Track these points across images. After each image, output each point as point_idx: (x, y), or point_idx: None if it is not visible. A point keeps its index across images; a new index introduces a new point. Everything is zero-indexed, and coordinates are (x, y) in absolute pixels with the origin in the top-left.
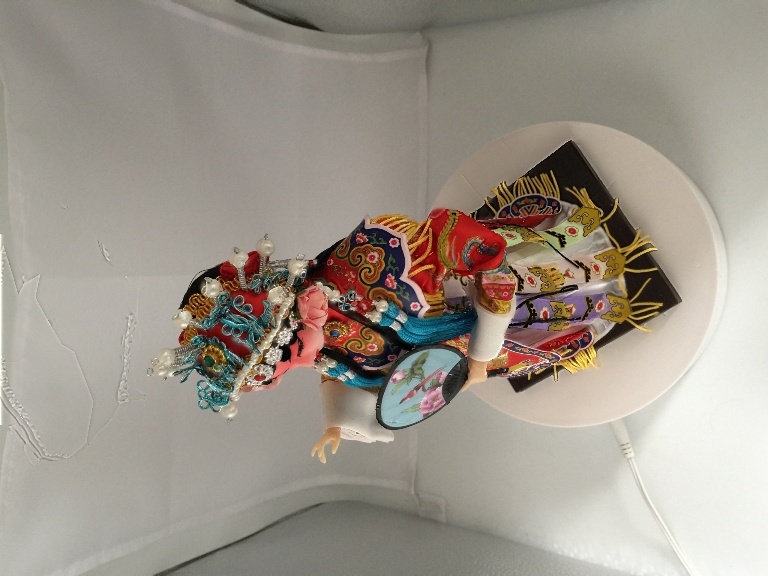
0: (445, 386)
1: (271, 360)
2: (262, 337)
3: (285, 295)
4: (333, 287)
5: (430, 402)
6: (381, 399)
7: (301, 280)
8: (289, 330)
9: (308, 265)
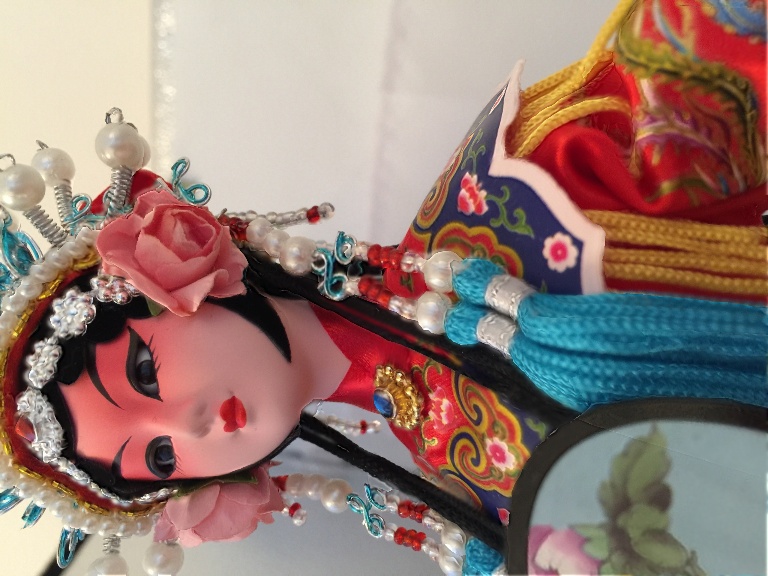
0: None
1: (34, 371)
2: None
3: (107, 223)
4: None
5: None
6: None
7: None
8: (85, 297)
9: None
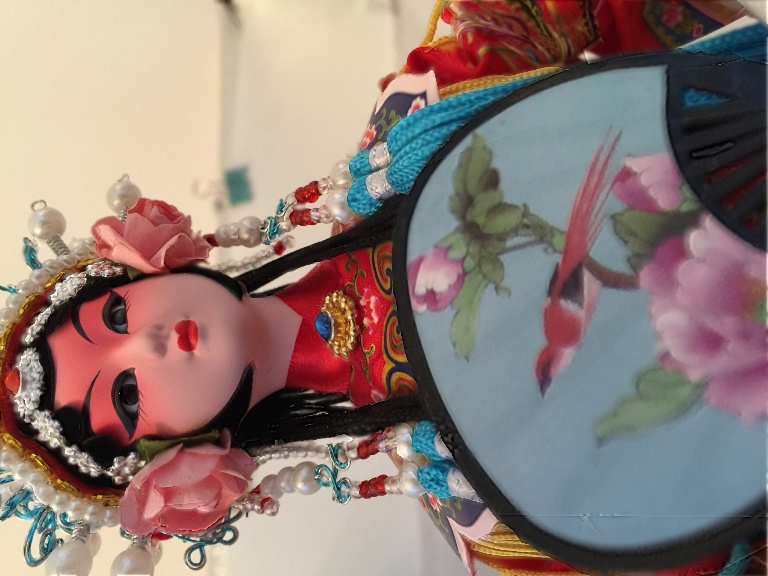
0: (746, 215)
1: (29, 332)
2: None
3: None
4: None
5: (741, 331)
6: (439, 402)
7: None
8: (80, 276)
9: None
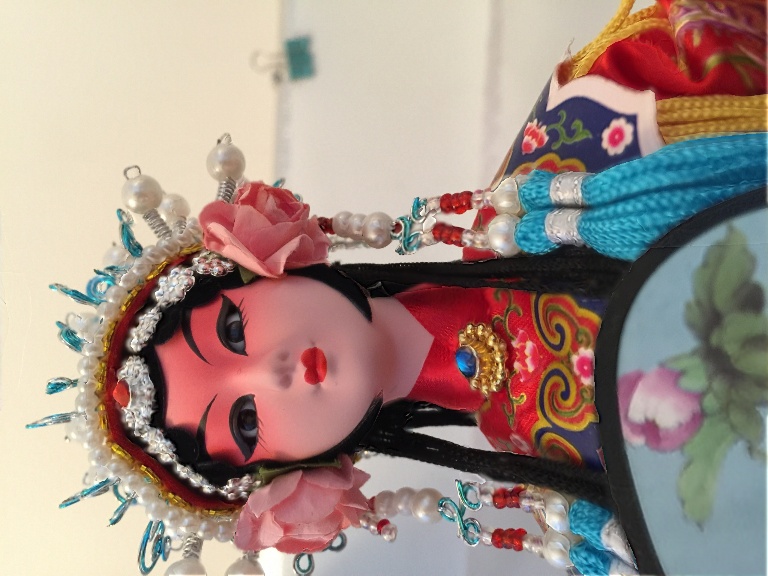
0: None
1: (135, 337)
2: None
3: None
4: None
5: None
6: (656, 565)
7: None
8: (187, 272)
9: None
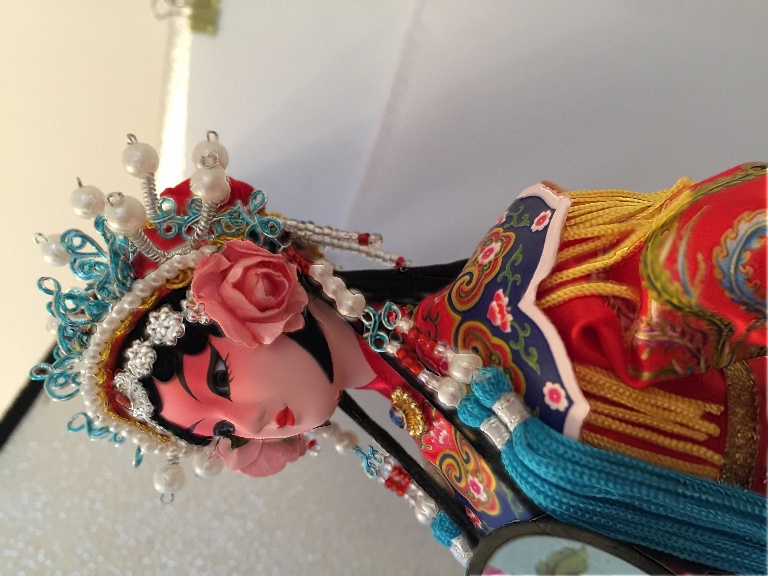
0: None
1: (133, 364)
2: (114, 305)
3: (194, 245)
4: (412, 312)
5: None
6: None
7: (276, 245)
8: (176, 315)
9: (405, 270)
